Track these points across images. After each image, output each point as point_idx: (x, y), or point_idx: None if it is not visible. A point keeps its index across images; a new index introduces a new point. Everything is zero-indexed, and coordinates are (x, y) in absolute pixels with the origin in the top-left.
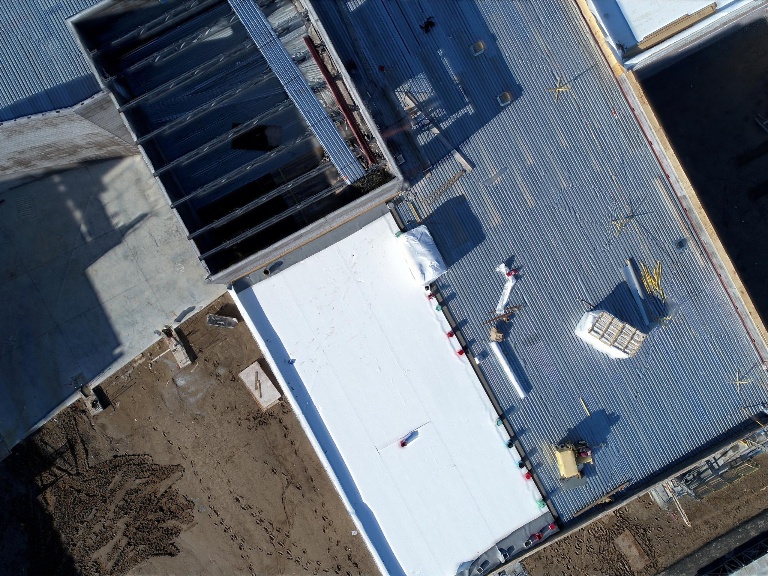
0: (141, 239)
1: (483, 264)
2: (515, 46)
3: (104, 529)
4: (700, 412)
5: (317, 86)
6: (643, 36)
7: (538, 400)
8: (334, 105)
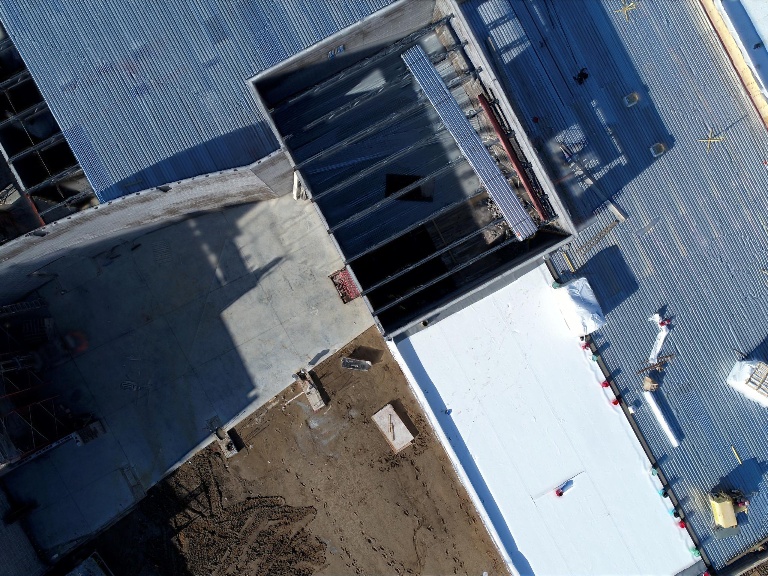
0: (276, 283)
1: (636, 314)
2: (667, 97)
3: (237, 570)
4: None
5: (490, 144)
6: None
7: (690, 449)
8: (506, 162)
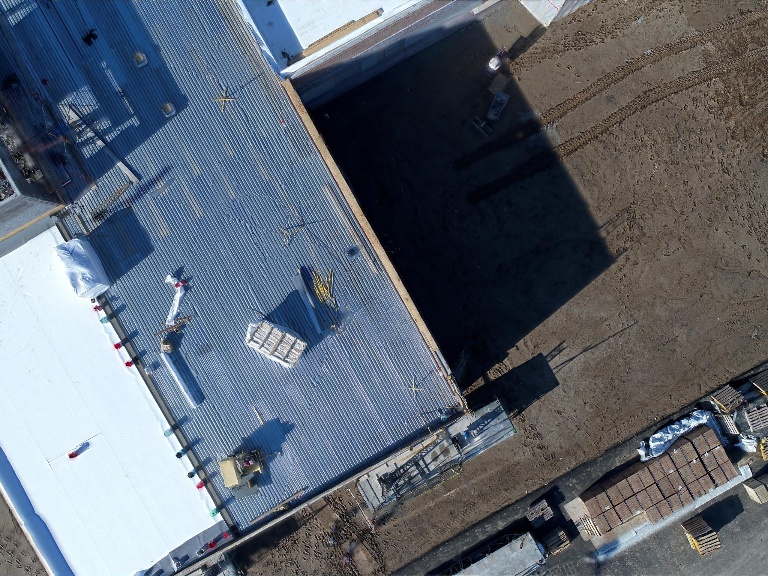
0: None
1: (152, 275)
2: (180, 57)
3: None
4: (376, 419)
5: None
6: (309, 44)
7: (211, 410)
8: None
